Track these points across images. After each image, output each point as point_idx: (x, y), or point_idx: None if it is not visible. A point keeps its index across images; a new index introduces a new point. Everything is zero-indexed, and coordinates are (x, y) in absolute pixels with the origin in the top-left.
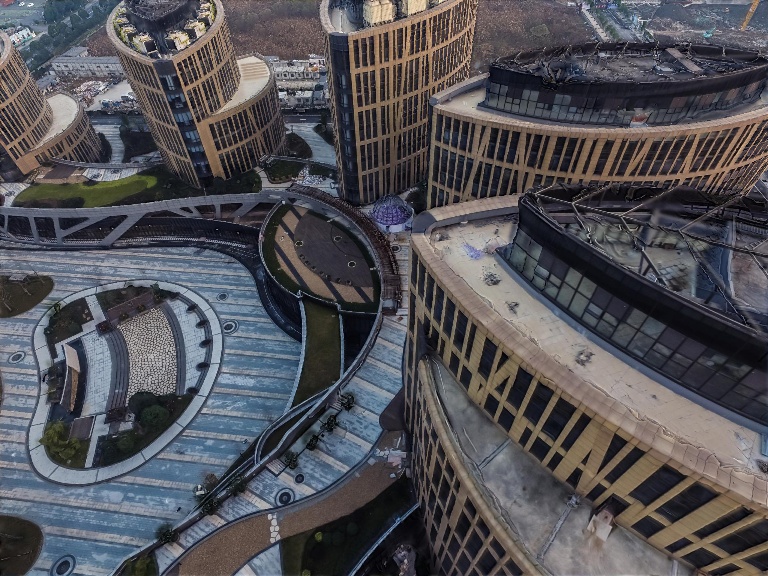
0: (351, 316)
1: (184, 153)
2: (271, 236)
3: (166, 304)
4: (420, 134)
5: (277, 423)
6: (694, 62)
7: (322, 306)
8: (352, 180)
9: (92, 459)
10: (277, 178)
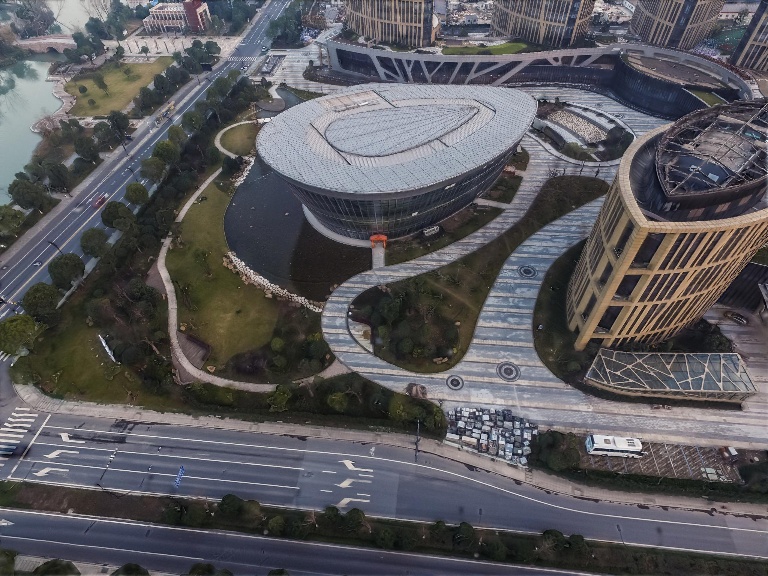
0: (720, 92)
1: (564, 19)
2: (632, 66)
3: (566, 109)
4: (720, 4)
5: None
6: None
7: (697, 90)
8: (678, 33)
9: (598, 159)
10: (609, 41)
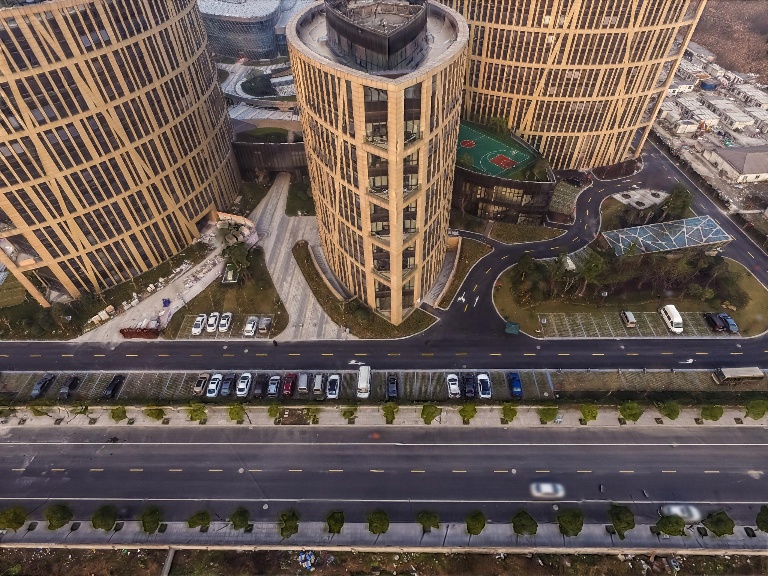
0: None
1: None
2: None
3: None
4: None
5: None
6: (369, 6)
7: None
8: None
9: None
10: None
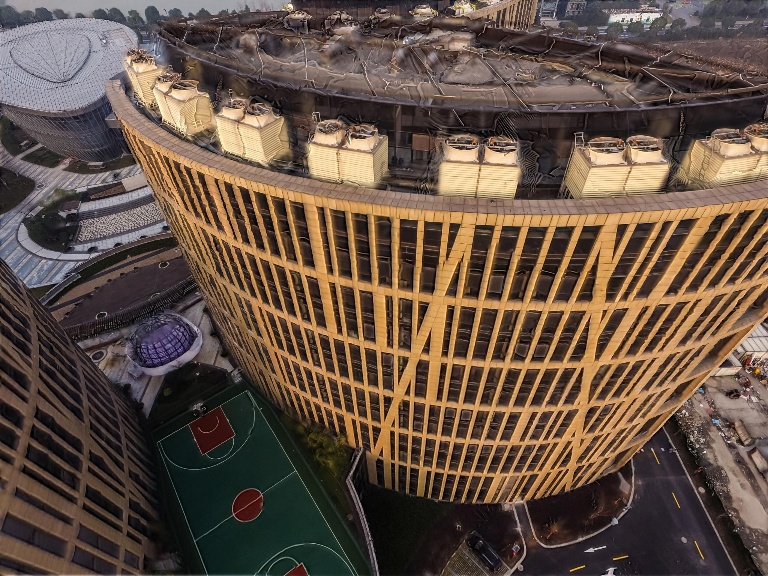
0: None
1: None
2: None
3: None
4: None
5: None
6: None
7: None
8: None
9: None
10: None
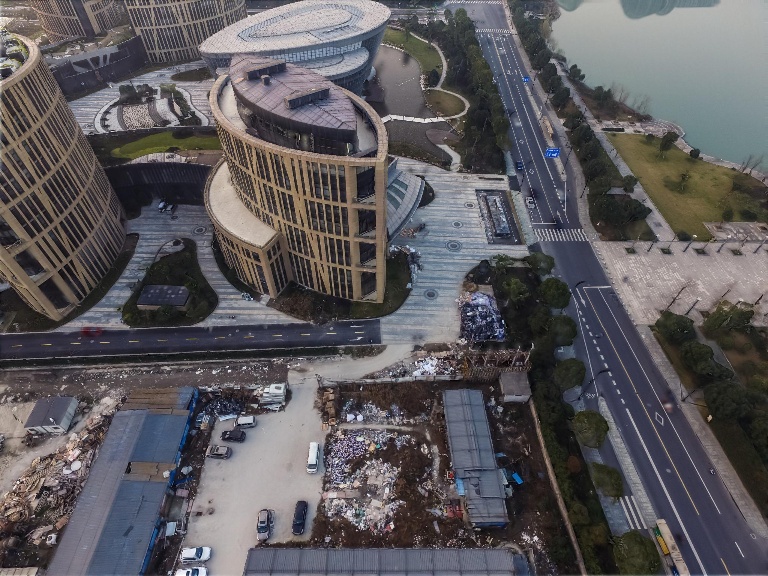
0: None
1: None
2: None
3: None
4: None
5: (57, 68)
6: None
7: None
8: None
9: None
10: None
